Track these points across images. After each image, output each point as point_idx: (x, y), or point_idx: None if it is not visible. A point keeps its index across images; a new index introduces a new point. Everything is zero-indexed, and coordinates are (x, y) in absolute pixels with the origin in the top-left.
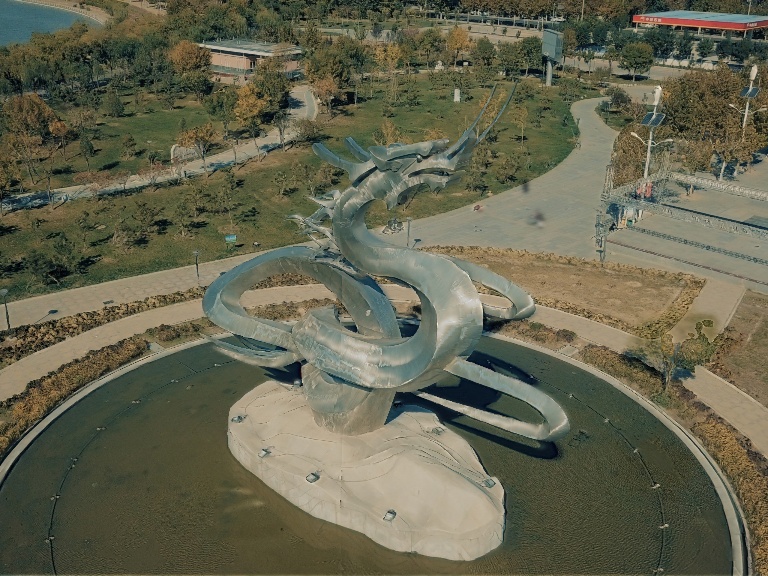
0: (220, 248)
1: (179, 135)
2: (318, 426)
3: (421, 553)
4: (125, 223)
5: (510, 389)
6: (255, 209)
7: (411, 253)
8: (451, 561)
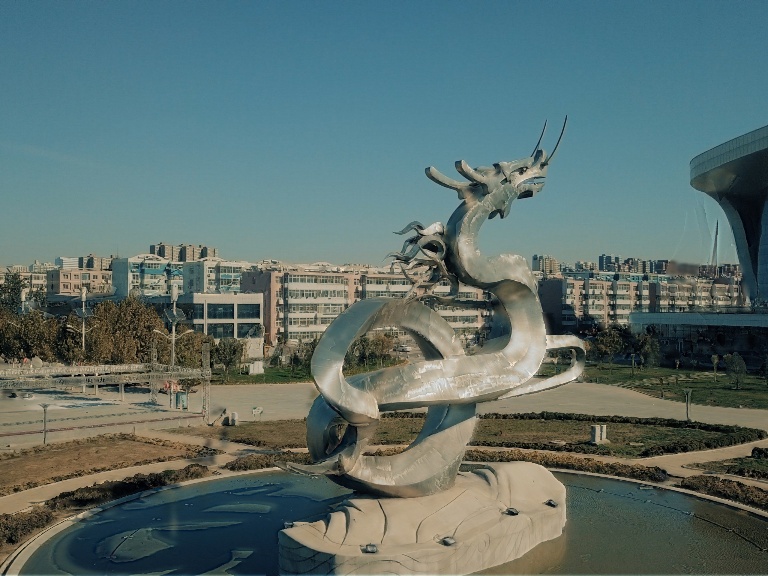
0: None
1: None
2: (432, 495)
3: None
4: None
5: None
6: None
7: (508, 256)
8: None
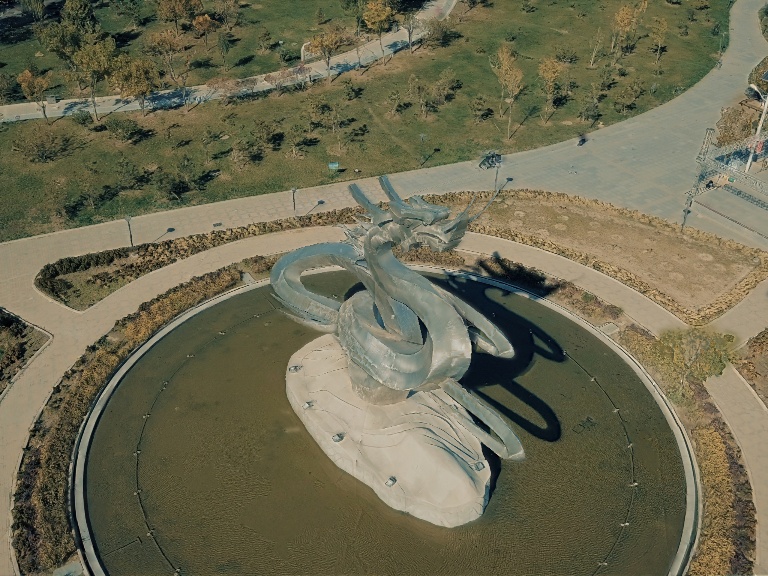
0: (324, 172)
1: (315, 24)
2: (353, 391)
3: (412, 514)
4: (242, 143)
5: (483, 416)
6: (366, 127)
7: (420, 289)
8: (435, 525)
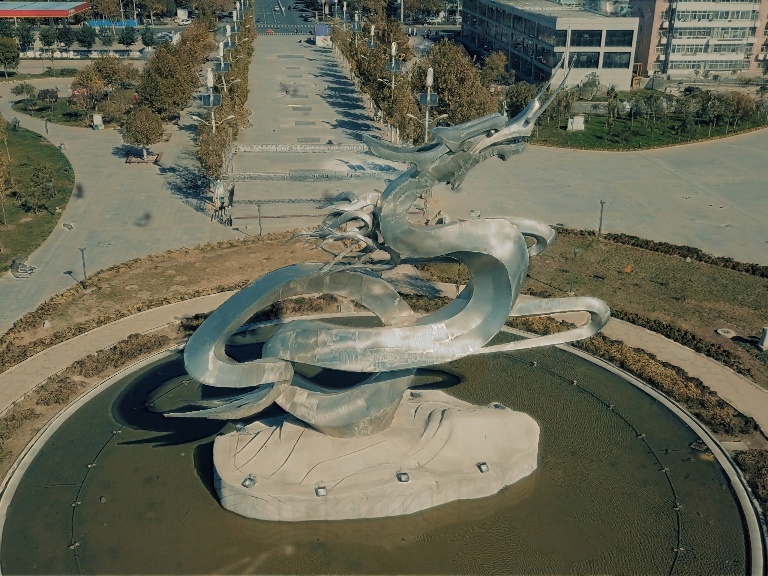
0: None
1: None
2: (348, 439)
3: (509, 484)
4: None
5: (571, 306)
6: None
7: (469, 224)
8: (528, 476)
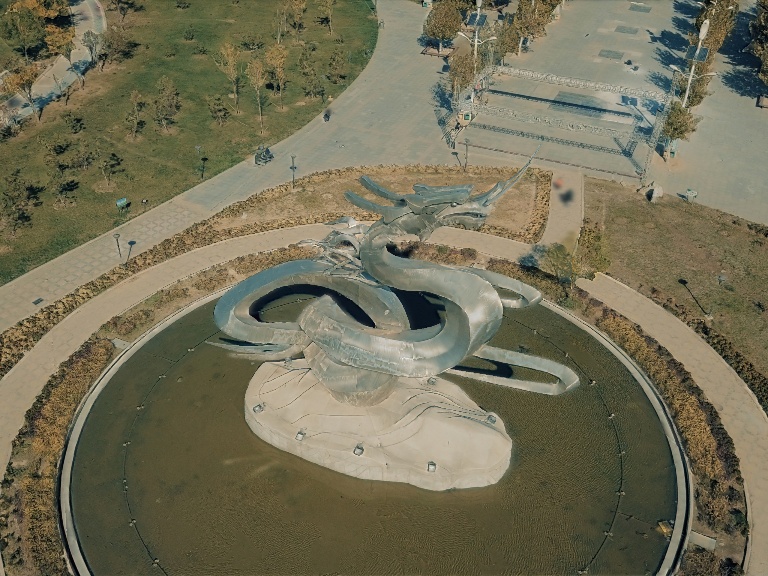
0: (110, 212)
1: None
2: (340, 403)
3: (459, 488)
4: (8, 207)
5: (533, 365)
6: (116, 156)
7: (440, 272)
8: (482, 488)
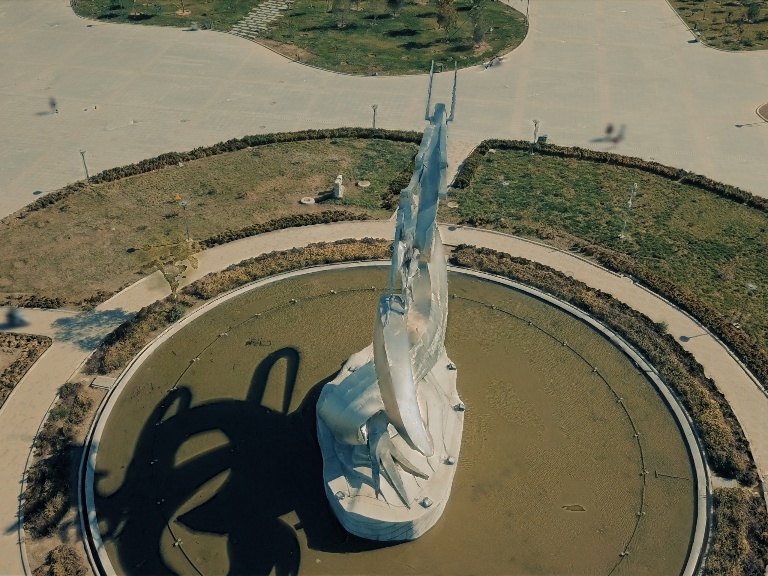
0: None
1: None
2: None
3: None
4: None
5: None
6: None
7: None
8: None
